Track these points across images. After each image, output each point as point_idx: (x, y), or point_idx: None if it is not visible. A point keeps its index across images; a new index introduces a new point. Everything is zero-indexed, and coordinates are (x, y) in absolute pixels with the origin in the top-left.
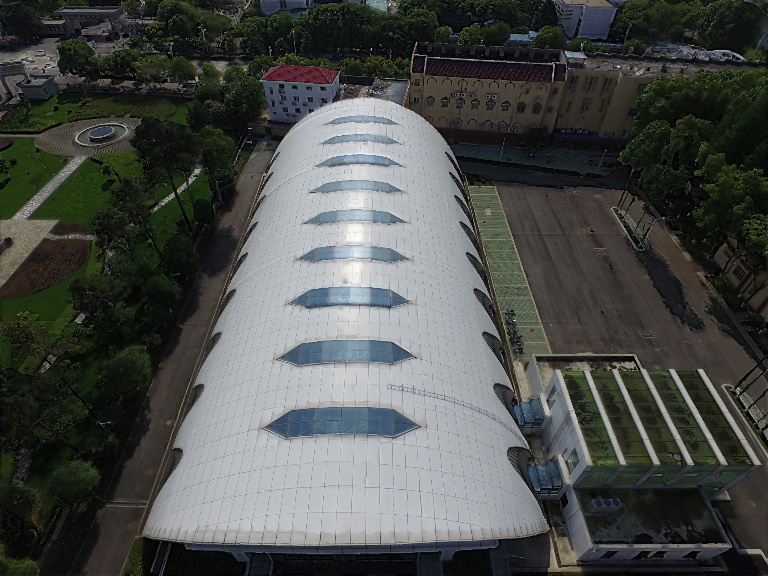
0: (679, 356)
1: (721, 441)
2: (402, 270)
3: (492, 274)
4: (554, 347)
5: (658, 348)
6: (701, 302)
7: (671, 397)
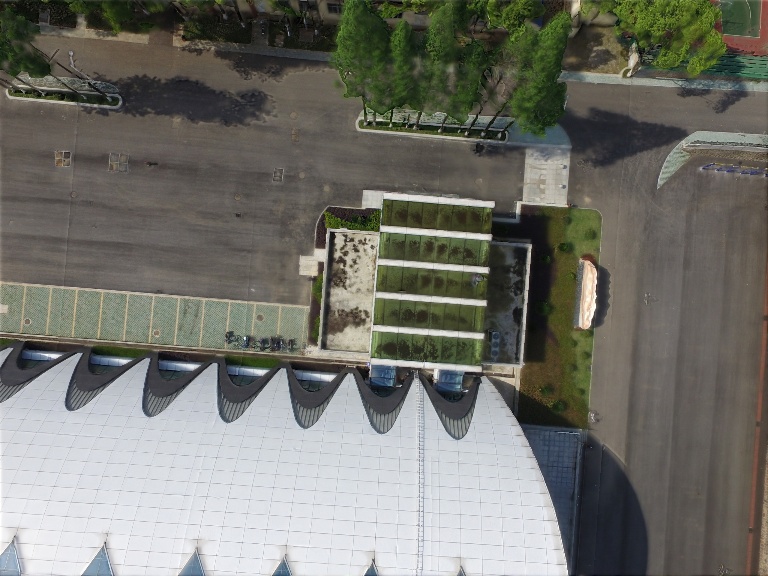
0: (314, 154)
1: (466, 224)
2: (221, 564)
3: (152, 342)
4: (288, 300)
5: (300, 173)
6: (231, 75)
7: (414, 247)
